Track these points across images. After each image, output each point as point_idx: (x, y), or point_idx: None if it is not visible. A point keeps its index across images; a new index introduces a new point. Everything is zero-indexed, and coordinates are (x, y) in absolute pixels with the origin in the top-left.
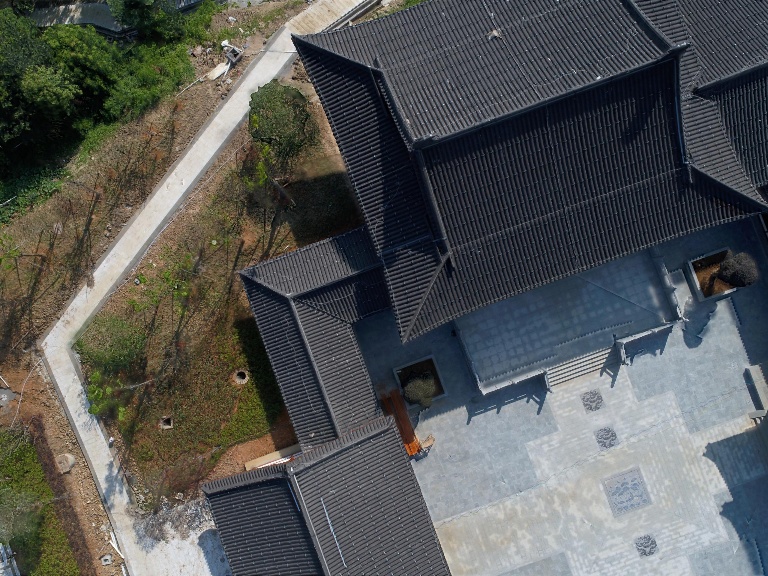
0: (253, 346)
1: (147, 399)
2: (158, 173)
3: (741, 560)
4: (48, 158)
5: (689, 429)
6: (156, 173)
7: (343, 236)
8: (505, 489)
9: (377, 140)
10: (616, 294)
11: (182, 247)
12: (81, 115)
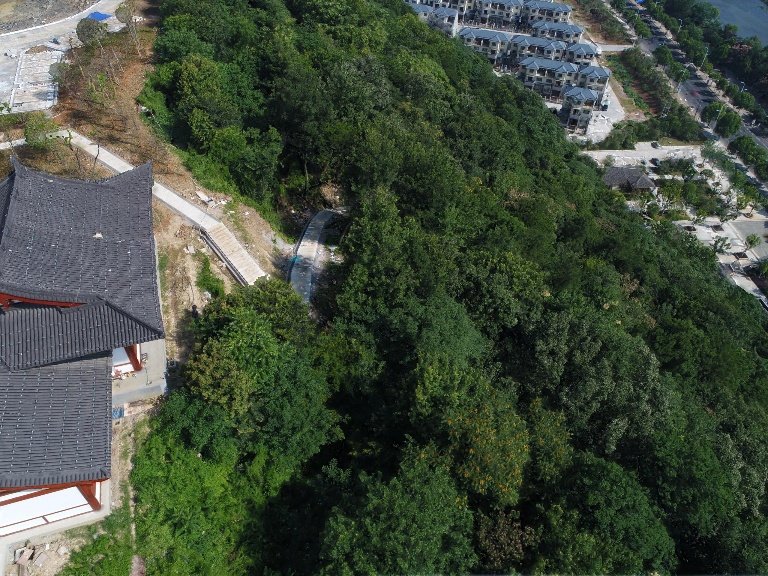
0: None
1: None
2: None
3: None
4: (181, 141)
5: None
6: None
7: None
8: None
9: None
10: None
11: None
12: (198, 149)
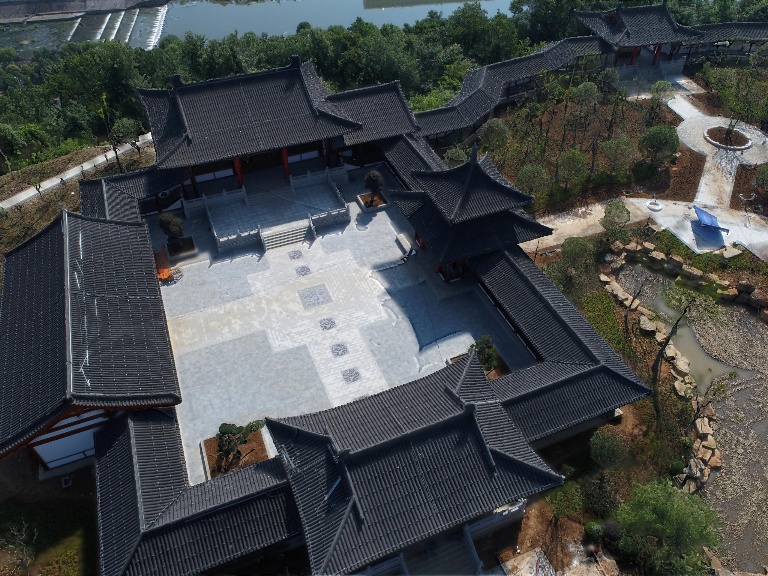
0: None
1: None
2: (54, 173)
3: (398, 330)
4: None
5: (359, 265)
6: (52, 173)
7: None
8: (227, 298)
9: None
10: (312, 206)
11: (52, 195)
12: (22, 161)
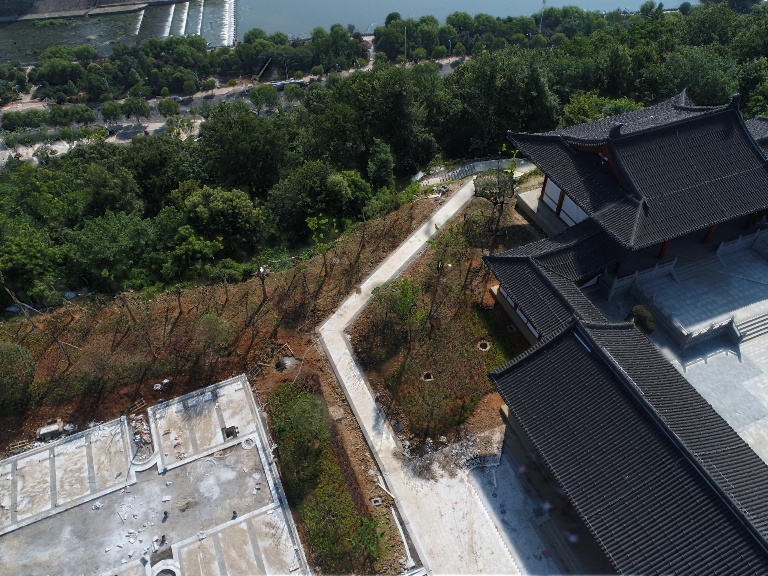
0: (490, 324)
1: (410, 358)
2: (403, 236)
3: None
4: (319, 241)
5: None
6: (402, 236)
7: (552, 238)
8: (742, 419)
9: (572, 167)
10: (757, 281)
11: (427, 269)
12: (345, 218)
